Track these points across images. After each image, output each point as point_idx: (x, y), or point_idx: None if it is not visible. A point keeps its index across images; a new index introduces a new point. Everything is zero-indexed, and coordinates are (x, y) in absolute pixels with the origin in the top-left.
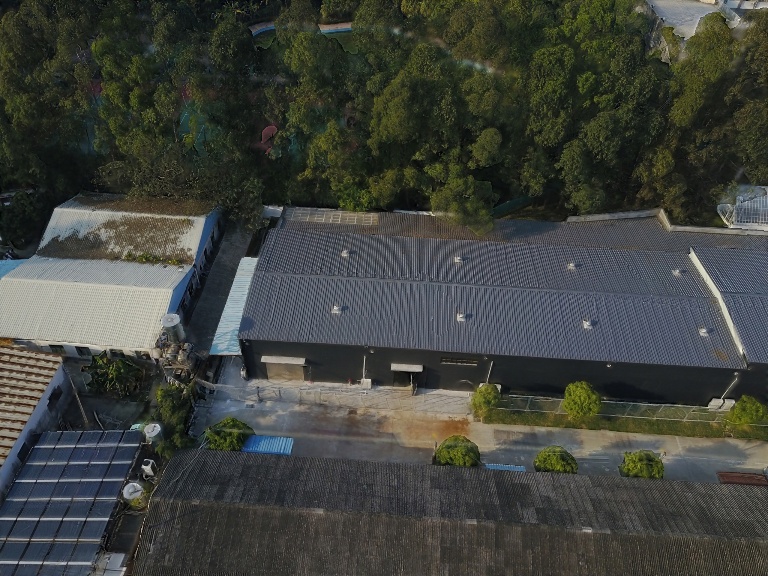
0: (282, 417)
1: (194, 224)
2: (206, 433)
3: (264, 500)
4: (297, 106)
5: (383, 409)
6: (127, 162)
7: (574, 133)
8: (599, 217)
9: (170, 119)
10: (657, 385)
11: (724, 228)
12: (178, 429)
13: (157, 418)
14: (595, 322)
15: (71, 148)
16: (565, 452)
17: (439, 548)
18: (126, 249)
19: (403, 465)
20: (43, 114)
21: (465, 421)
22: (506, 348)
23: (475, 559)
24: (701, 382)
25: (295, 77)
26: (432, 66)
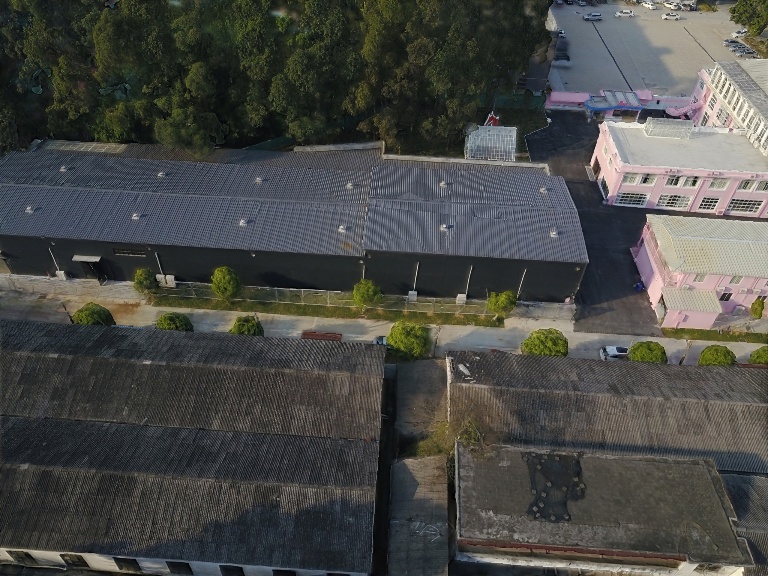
0: None
1: None
2: None
3: None
4: (28, 42)
5: (69, 295)
6: None
7: (282, 69)
8: (325, 148)
9: None
10: (304, 275)
11: (431, 156)
12: None
13: None
14: (251, 221)
15: None
16: (177, 315)
17: (20, 374)
18: None
19: (33, 323)
20: None
21: (137, 304)
22: (163, 239)
23: (47, 382)
24: (338, 271)
25: (25, 17)
26: (138, 6)
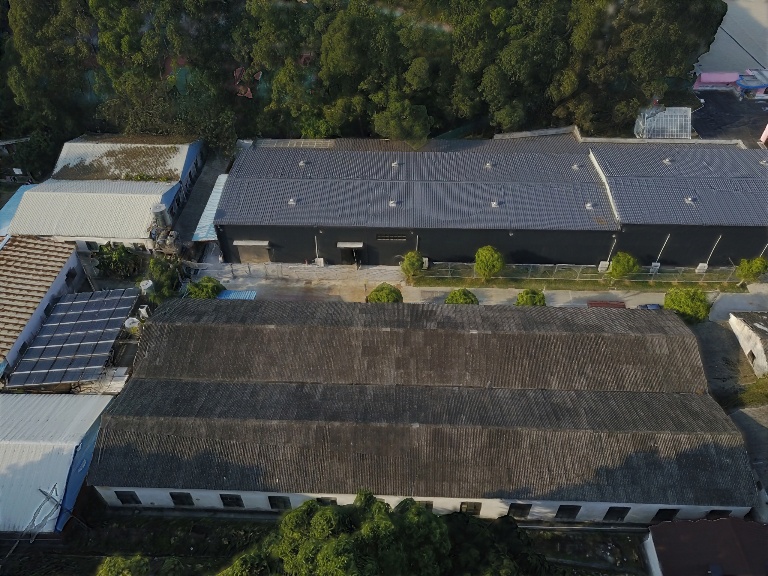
0: (252, 288)
1: (179, 150)
2: (187, 285)
3: (230, 322)
4: (259, 46)
5: (333, 280)
6: (122, 100)
7: (492, 60)
8: (522, 134)
9: (155, 60)
10: (553, 251)
11: (627, 138)
12: (166, 284)
13: (150, 278)
14: (501, 203)
15: (76, 94)
16: (468, 291)
17: (361, 347)
18: (124, 171)
19: (340, 303)
20: (52, 66)
21: (398, 286)
22: (427, 223)
23: (388, 353)
24: (588, 246)
25: (256, 22)
26: (367, 6)
